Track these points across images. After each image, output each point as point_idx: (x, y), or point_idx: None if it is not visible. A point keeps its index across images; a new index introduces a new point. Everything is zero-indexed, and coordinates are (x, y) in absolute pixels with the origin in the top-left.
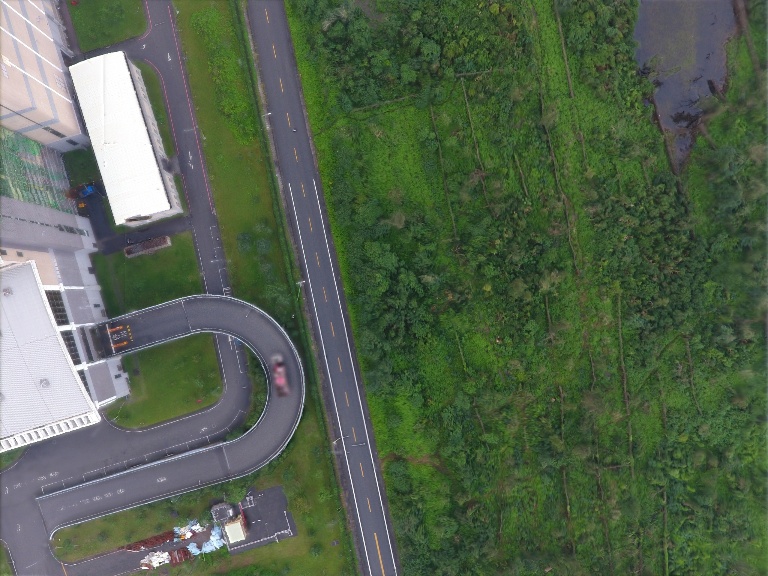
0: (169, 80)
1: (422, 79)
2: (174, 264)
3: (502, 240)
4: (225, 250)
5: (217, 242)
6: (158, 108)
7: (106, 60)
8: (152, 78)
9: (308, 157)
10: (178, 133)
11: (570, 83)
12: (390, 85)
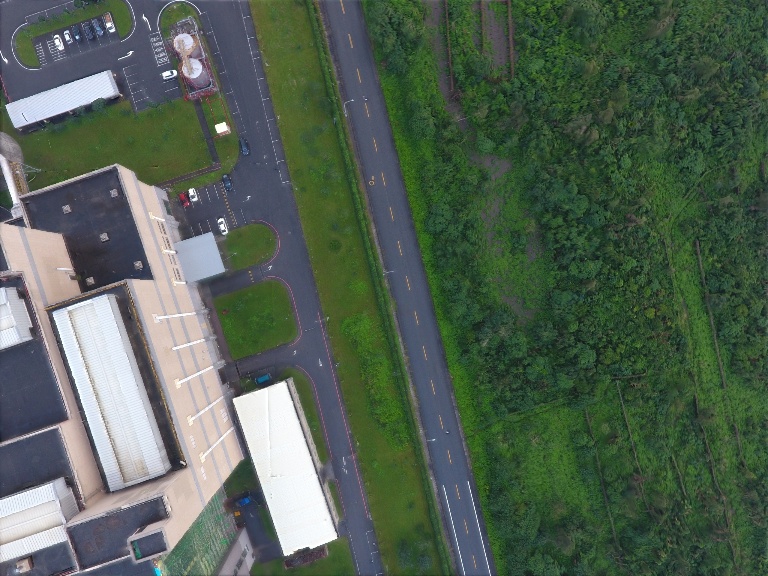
0: (321, 385)
1: (578, 385)
2: (332, 571)
3: (666, 550)
4: (383, 558)
5: (373, 547)
6: (311, 414)
7: (270, 392)
8: (304, 384)
9: (462, 459)
10: (331, 438)
11: (723, 375)
12: (544, 388)
